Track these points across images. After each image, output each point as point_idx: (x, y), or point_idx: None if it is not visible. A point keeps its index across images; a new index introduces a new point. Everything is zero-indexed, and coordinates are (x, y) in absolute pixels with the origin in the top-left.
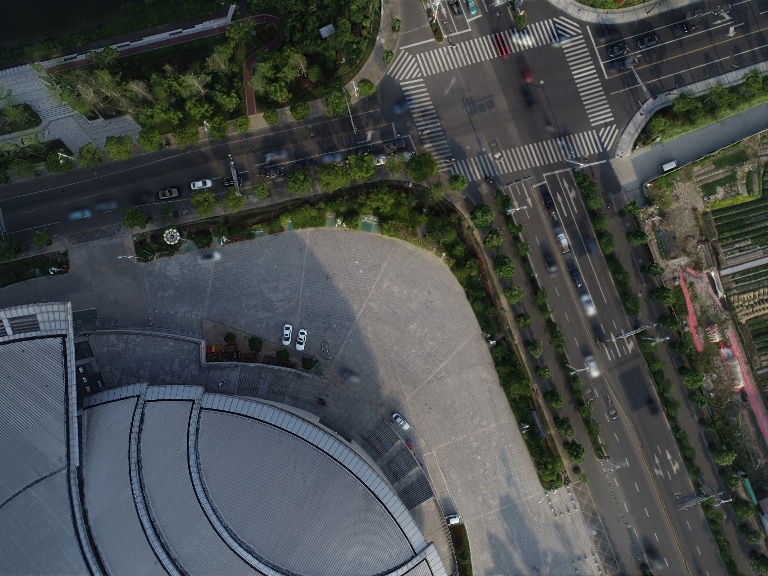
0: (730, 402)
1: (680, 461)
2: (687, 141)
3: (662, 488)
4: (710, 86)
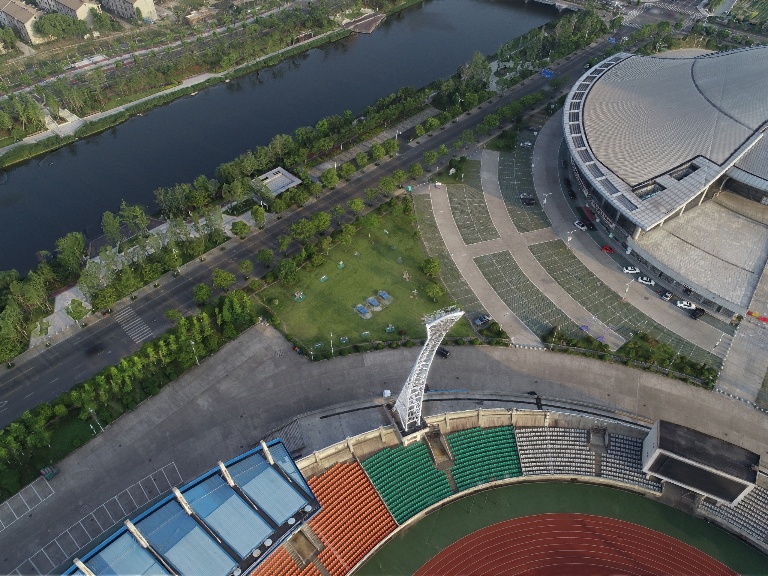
0: None
1: None
2: None
3: None
4: (707, 0)
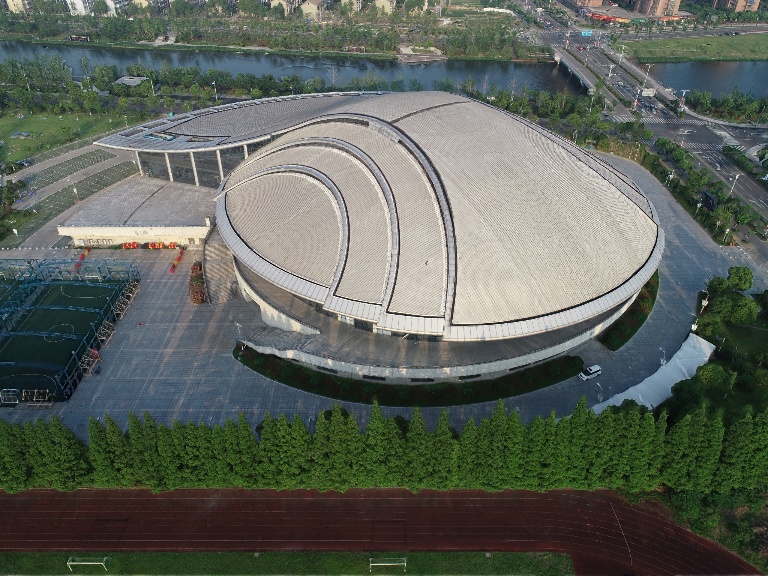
0: None
1: None
2: None
3: None
4: None
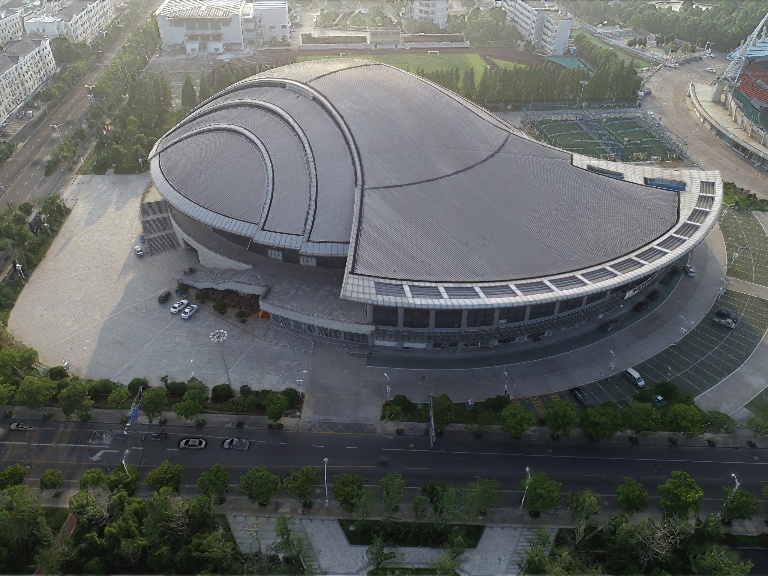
0: None
1: None
2: None
3: None
4: None
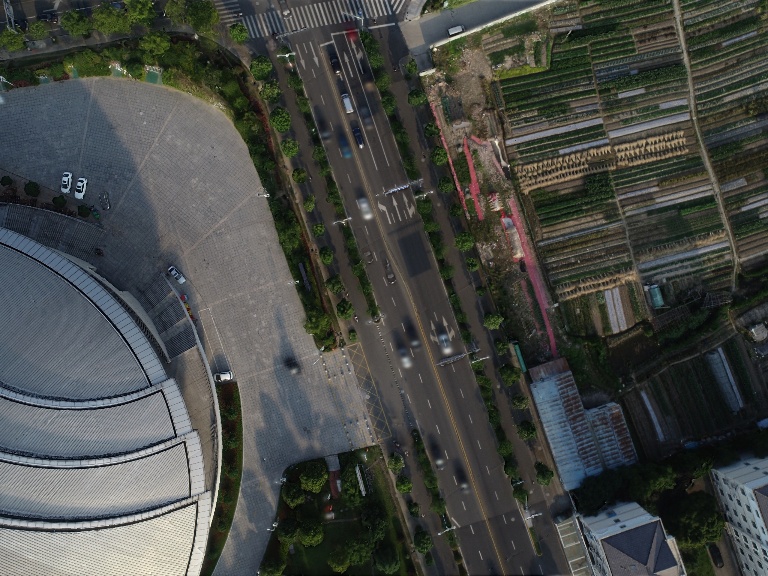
0: (509, 272)
1: (456, 328)
2: (477, 9)
3: (437, 355)
4: None
